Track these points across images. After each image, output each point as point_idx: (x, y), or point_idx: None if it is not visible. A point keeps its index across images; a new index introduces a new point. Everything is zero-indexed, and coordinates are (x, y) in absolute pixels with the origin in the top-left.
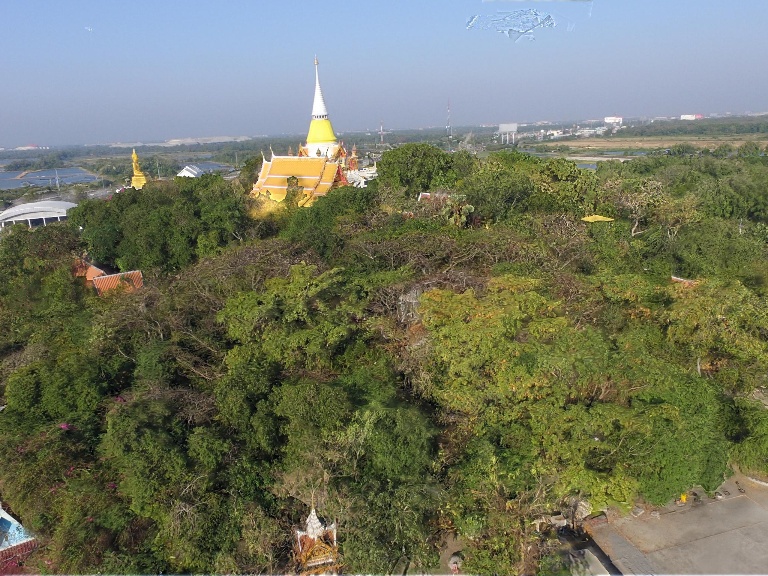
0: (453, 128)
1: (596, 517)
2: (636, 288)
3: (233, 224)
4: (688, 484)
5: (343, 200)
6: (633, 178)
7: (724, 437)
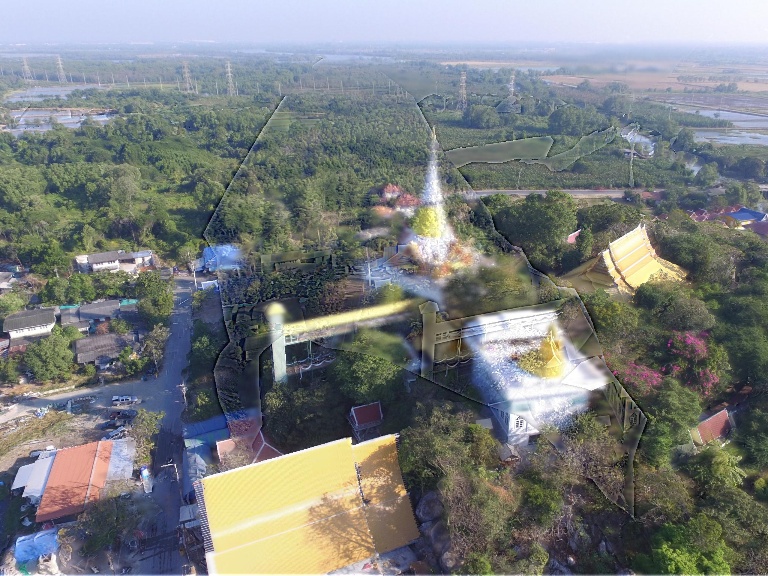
0: None
1: None
2: None
3: None
4: None
5: None
6: (566, 193)
7: None
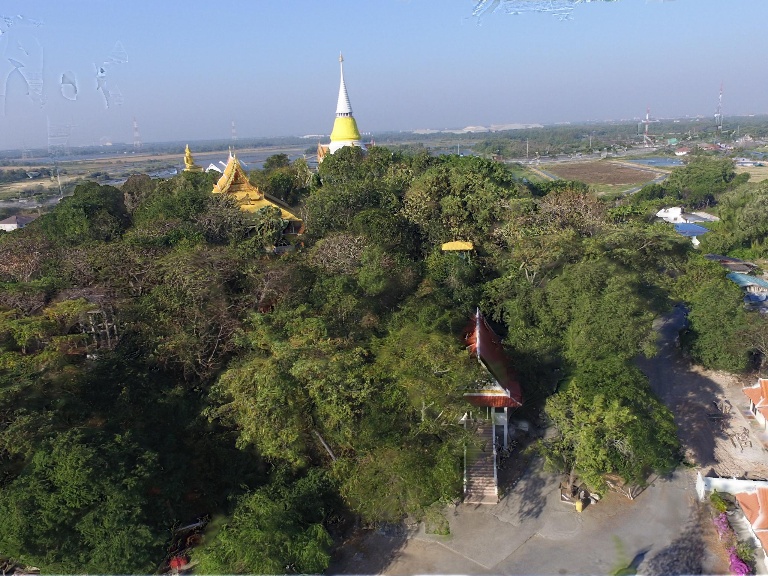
0: (724, 117)
1: (28, 574)
2: (303, 336)
3: (87, 220)
4: (62, 571)
5: (177, 204)
6: None
7: (146, 534)
